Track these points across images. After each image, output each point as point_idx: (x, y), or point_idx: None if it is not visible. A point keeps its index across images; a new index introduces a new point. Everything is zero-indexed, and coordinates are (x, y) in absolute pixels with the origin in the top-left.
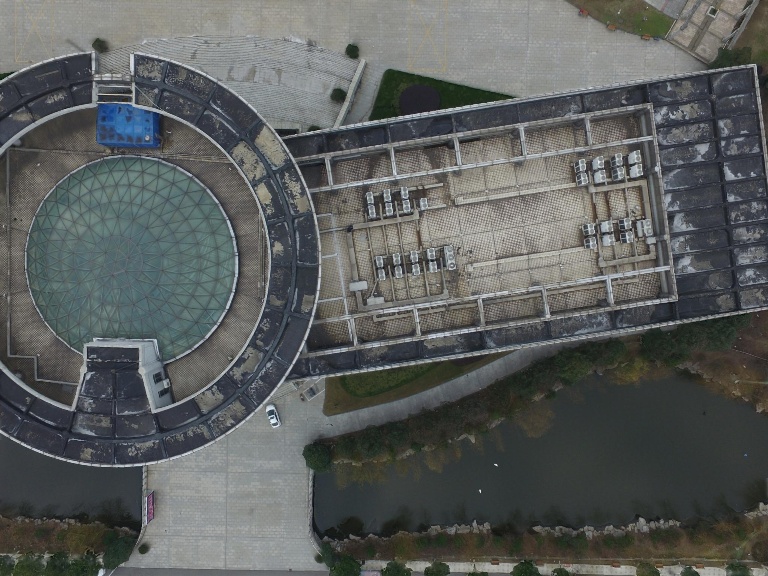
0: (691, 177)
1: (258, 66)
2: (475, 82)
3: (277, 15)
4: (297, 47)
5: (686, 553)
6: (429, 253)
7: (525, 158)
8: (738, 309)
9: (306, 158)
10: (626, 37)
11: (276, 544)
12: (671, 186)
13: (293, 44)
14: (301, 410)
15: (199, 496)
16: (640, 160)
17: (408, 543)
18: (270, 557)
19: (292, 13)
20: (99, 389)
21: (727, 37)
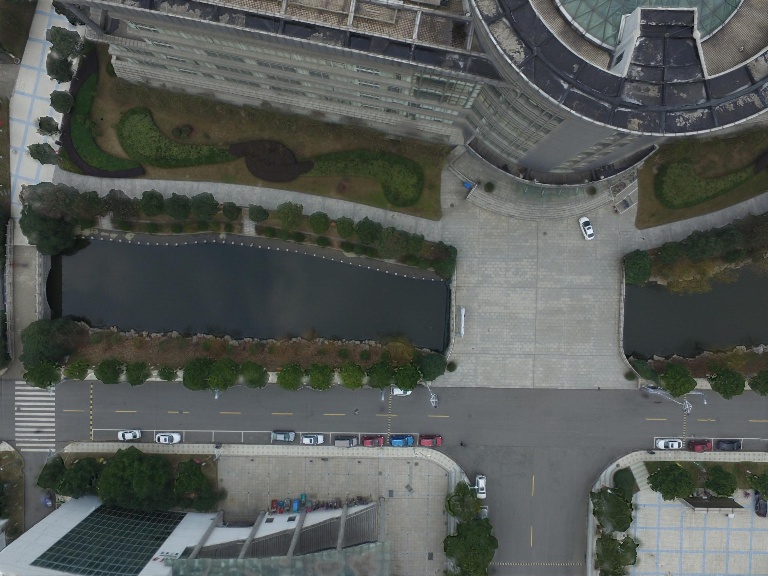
0: None
1: None
2: None
3: None
4: None
5: None
6: None
7: None
8: None
9: None
10: None
11: (585, 362)
12: None
13: None
14: (613, 223)
15: (508, 313)
16: None
17: (716, 362)
18: (579, 375)
19: None
20: (648, 56)
21: None
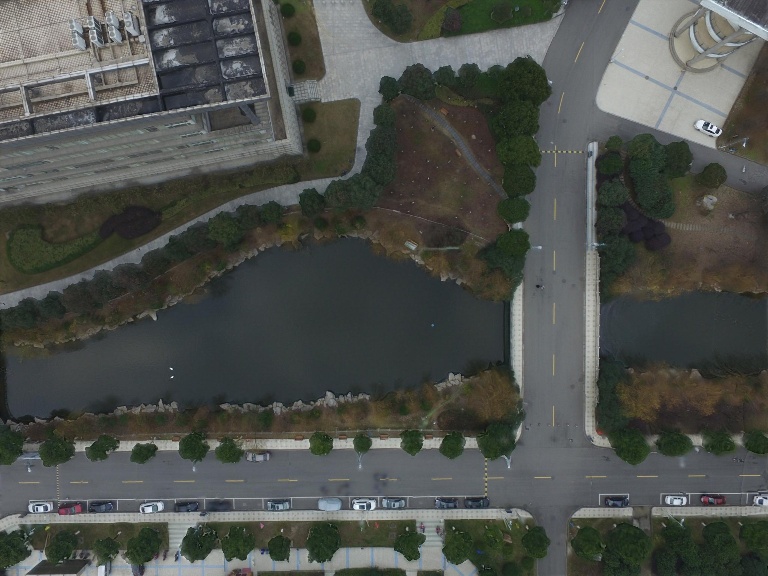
0: None
1: None
2: None
3: None
4: None
5: (371, 425)
6: None
7: None
8: (222, 101)
9: None
10: None
11: None
12: None
13: None
14: None
15: None
16: None
17: (92, 424)
18: None
19: None
20: None
21: None
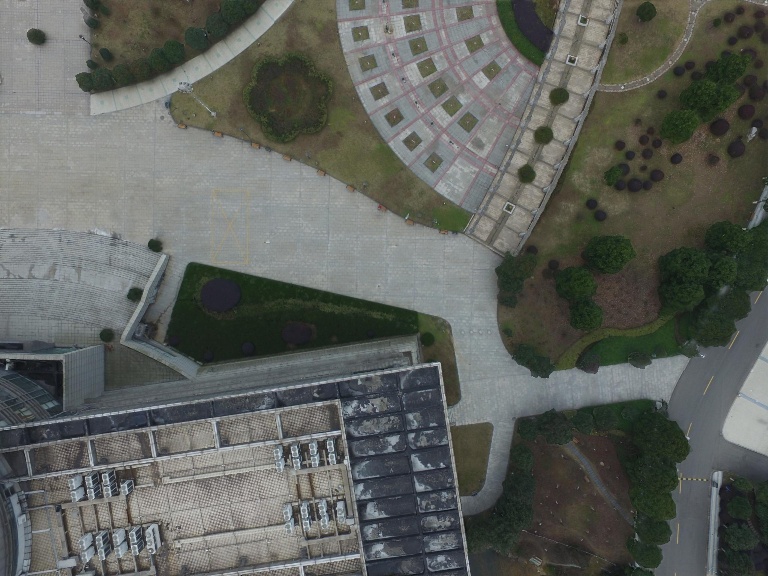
0: (382, 467)
1: (59, 264)
2: (277, 274)
3: (83, 209)
4: (101, 241)
5: None
6: (130, 537)
7: (218, 451)
8: None
9: (6, 450)
10: (425, 231)
11: None
12: (363, 475)
13: (98, 237)
14: None
15: None
16: (332, 450)
17: None
18: None
19: (97, 207)
20: None
21: (521, 234)
